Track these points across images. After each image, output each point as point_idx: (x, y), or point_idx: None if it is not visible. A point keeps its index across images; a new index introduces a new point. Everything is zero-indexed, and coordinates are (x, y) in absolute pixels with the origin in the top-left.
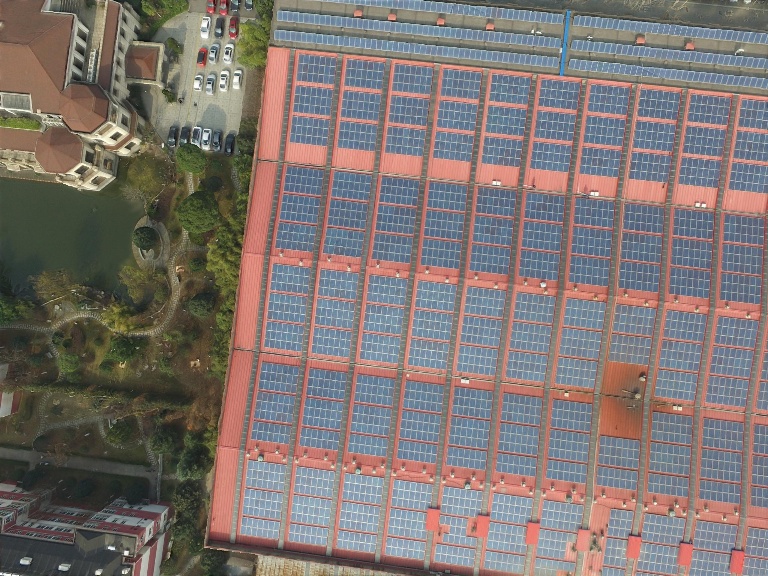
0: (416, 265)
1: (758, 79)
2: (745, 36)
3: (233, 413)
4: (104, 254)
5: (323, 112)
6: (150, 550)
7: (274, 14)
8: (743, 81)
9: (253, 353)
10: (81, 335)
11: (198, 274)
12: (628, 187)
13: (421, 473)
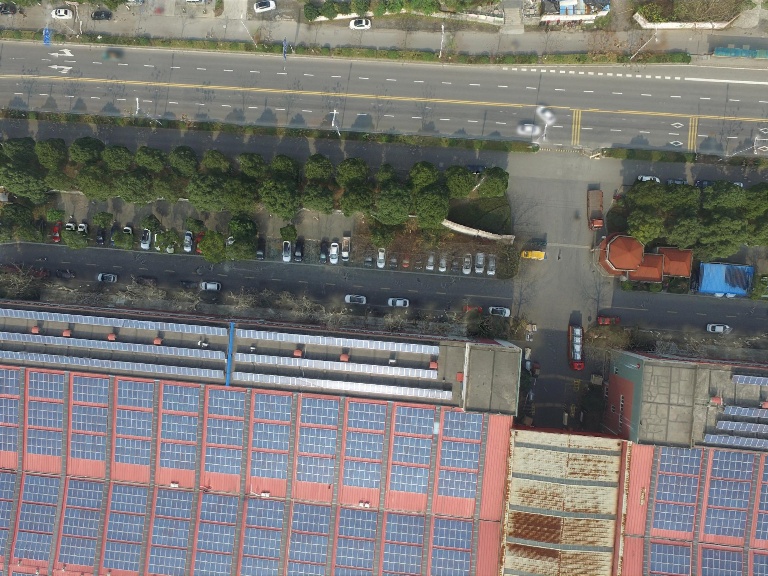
0: (99, 568)
1: (409, 389)
2: (397, 346)
3: None
4: None
5: (11, 421)
6: None
7: None
8: (395, 390)
9: None
10: None
11: None
12: (297, 488)
13: None
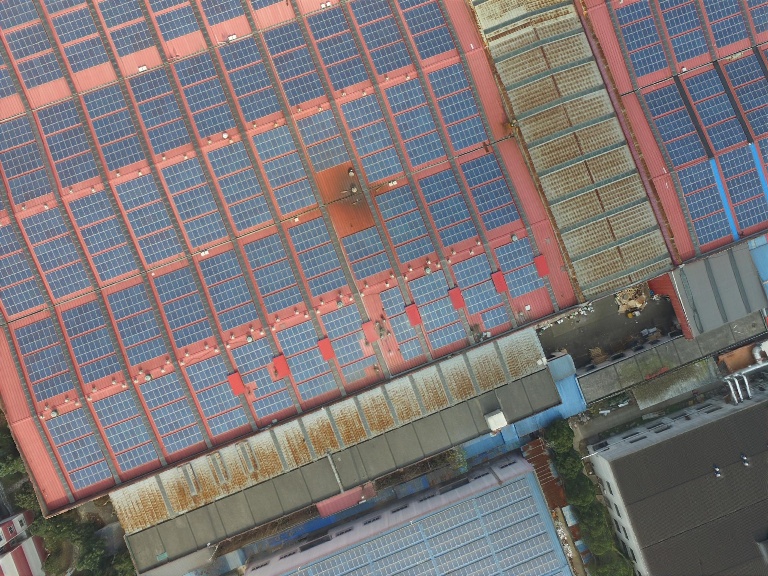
0: (106, 174)
1: None
2: None
3: (10, 389)
4: None
5: None
6: (11, 555)
7: None
8: None
9: (1, 327)
10: None
11: None
12: (258, 18)
13: (205, 350)
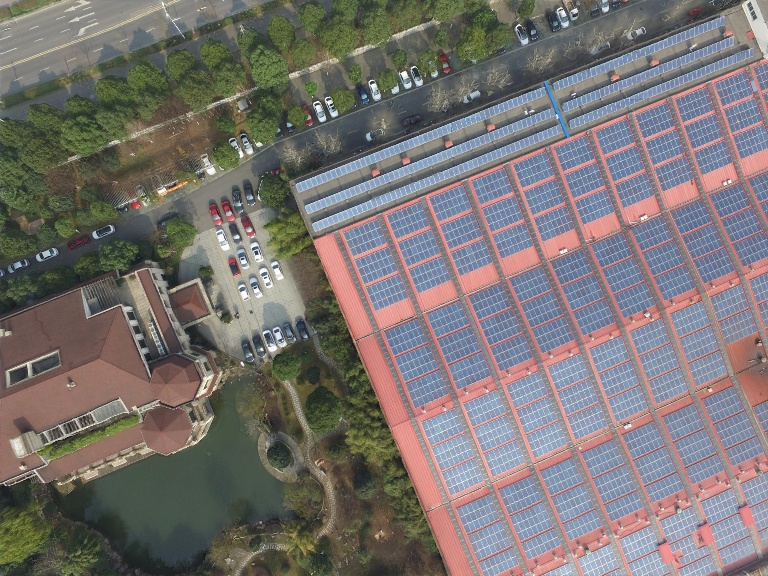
0: (539, 356)
1: (719, 62)
2: (691, 32)
3: (457, 567)
4: (242, 488)
5: (390, 271)
6: None
7: (302, 210)
8: (708, 69)
9: (444, 506)
10: (265, 572)
11: (339, 458)
12: (666, 198)
13: (637, 522)
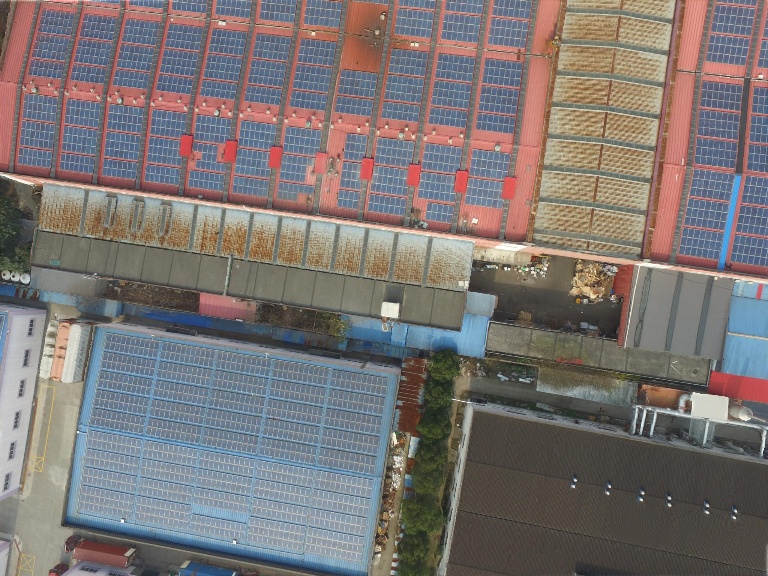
0: None
1: None
2: None
3: (14, 53)
4: None
5: None
6: None
7: None
8: None
9: (35, 2)
10: None
11: None
12: None
13: (177, 103)
